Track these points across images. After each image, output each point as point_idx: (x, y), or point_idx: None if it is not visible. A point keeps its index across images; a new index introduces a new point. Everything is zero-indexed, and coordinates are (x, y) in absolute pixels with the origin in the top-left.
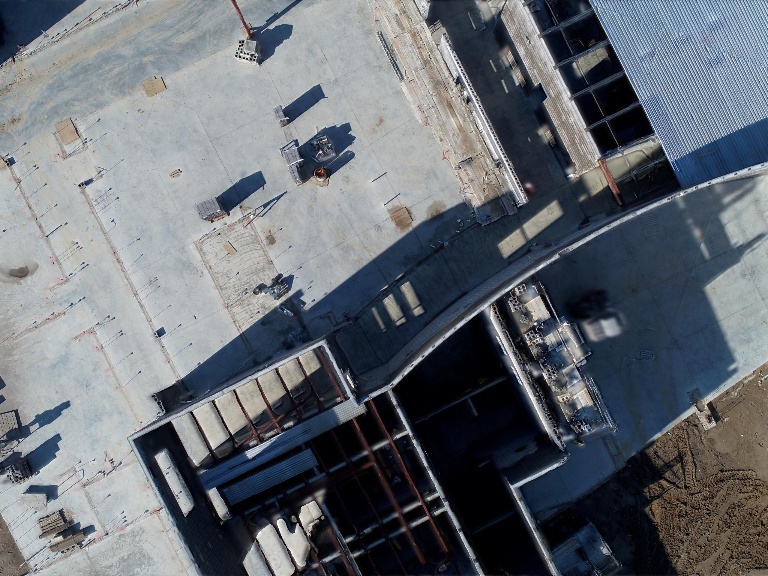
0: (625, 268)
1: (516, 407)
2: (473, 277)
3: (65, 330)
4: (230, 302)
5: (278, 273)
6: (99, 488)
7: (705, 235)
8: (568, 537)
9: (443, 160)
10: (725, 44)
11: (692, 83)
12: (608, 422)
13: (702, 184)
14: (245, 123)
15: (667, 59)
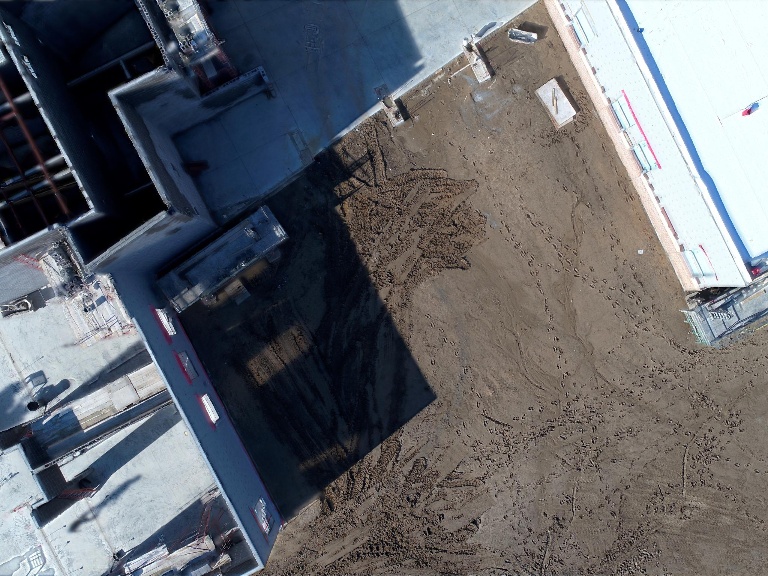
0: None
1: None
2: None
3: None
4: None
5: None
6: None
7: None
8: (243, 220)
9: None
10: None
11: None
12: (205, 31)
13: None
14: None
15: None
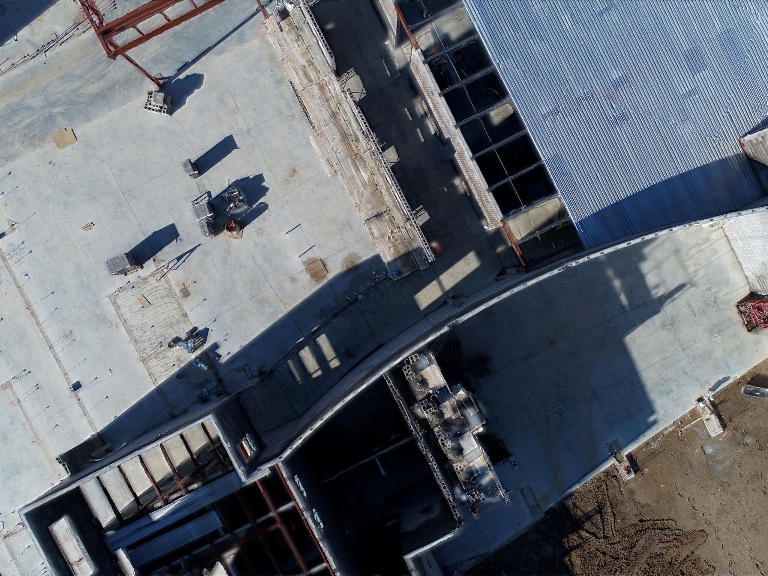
0: (543, 319)
1: None
2: (389, 329)
3: None
4: (145, 355)
5: (193, 326)
6: (19, 539)
7: (625, 285)
8: None
9: None
10: (632, 101)
11: (597, 141)
12: (500, 493)
13: (594, 254)
14: (157, 175)
15: (571, 117)
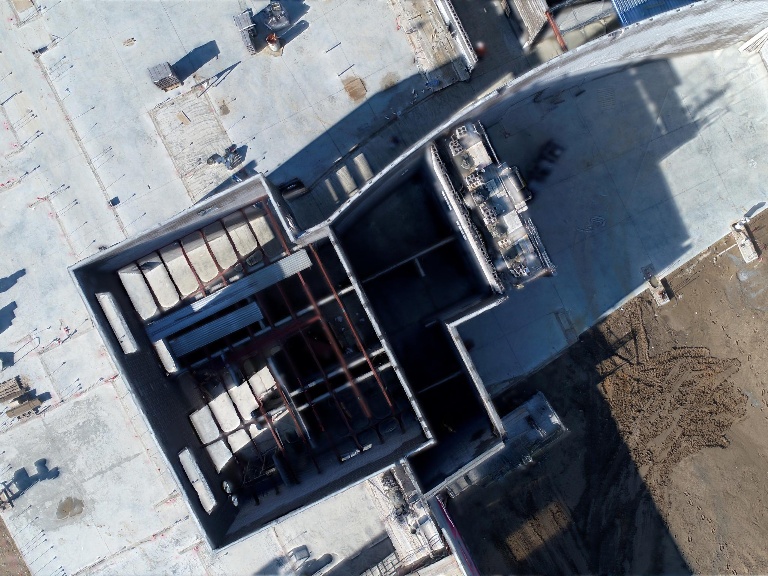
0: (580, 142)
1: (468, 280)
2: None
3: (20, 198)
4: (184, 172)
5: (232, 143)
6: (54, 356)
7: (662, 109)
8: (517, 406)
9: (398, 31)
10: None
11: None
12: (546, 263)
13: (644, 20)
14: None
15: None
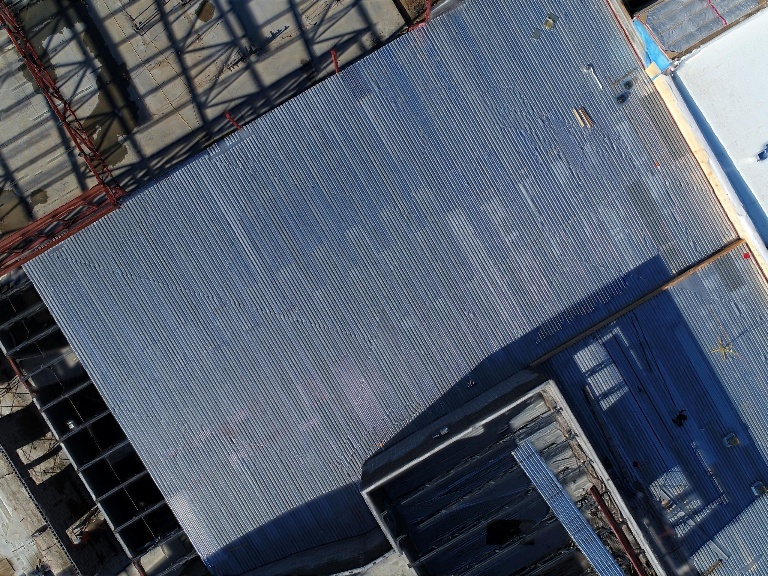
0: None
1: None
2: None
3: None
4: None
5: None
6: None
7: None
8: None
9: None
10: (251, 434)
11: (219, 477)
12: None
13: None
14: None
15: (191, 455)
